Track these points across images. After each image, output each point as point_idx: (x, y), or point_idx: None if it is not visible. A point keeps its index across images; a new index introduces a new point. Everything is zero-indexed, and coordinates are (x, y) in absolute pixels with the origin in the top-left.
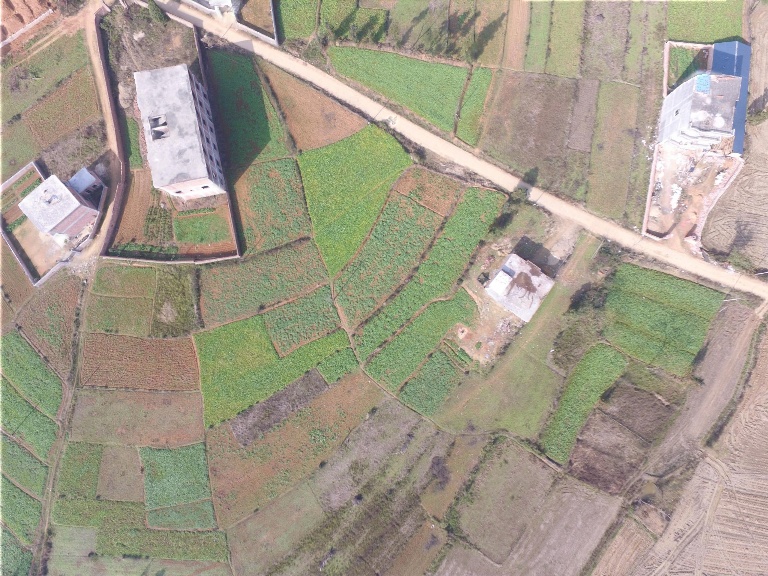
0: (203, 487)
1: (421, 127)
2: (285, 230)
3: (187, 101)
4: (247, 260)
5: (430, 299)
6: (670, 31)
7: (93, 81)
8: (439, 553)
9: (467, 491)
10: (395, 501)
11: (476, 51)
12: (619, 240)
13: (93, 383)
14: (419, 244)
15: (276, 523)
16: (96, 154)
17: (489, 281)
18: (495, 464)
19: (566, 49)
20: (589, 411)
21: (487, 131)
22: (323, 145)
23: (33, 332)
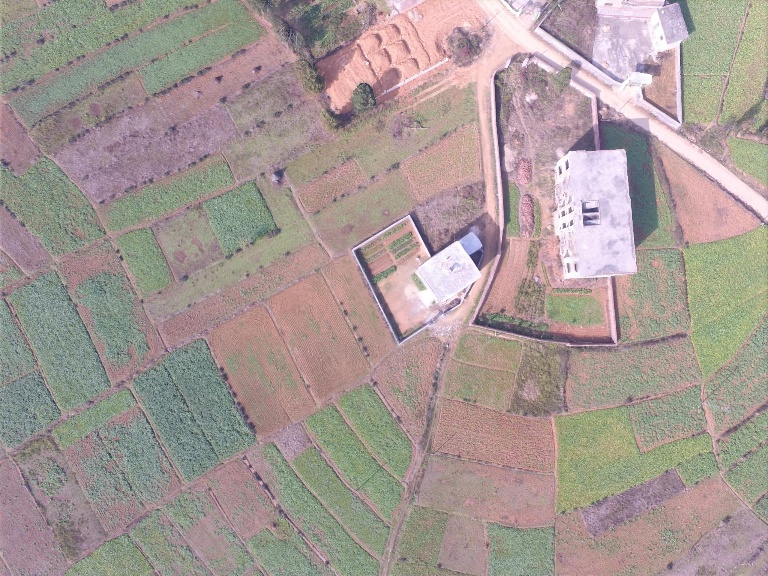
0: (548, 571)
1: None
2: (663, 323)
3: (623, 189)
4: (619, 348)
5: None
6: None
7: (478, 139)
8: None
9: None
10: None
11: None
12: None
13: (446, 450)
14: None
15: None
16: (472, 215)
17: None
18: None
19: None
20: None
21: None
22: (712, 240)
23: (388, 390)
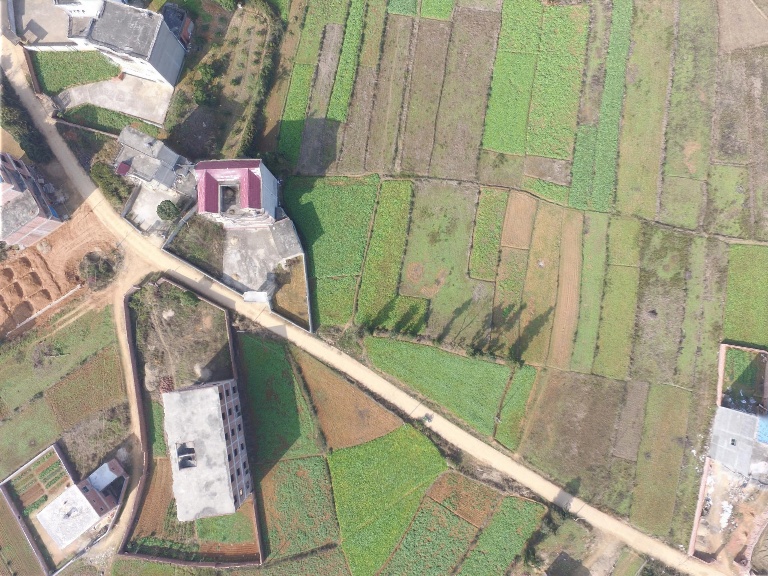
0: None
1: (459, 427)
2: (311, 535)
3: (217, 428)
4: (270, 564)
5: None
6: (727, 330)
7: (119, 360)
8: None
9: None
10: None
11: (520, 347)
12: (663, 559)
13: None
14: (451, 558)
15: None
16: (119, 438)
17: None
18: None
19: (615, 348)
20: None
21: (528, 435)
22: (355, 444)
23: None
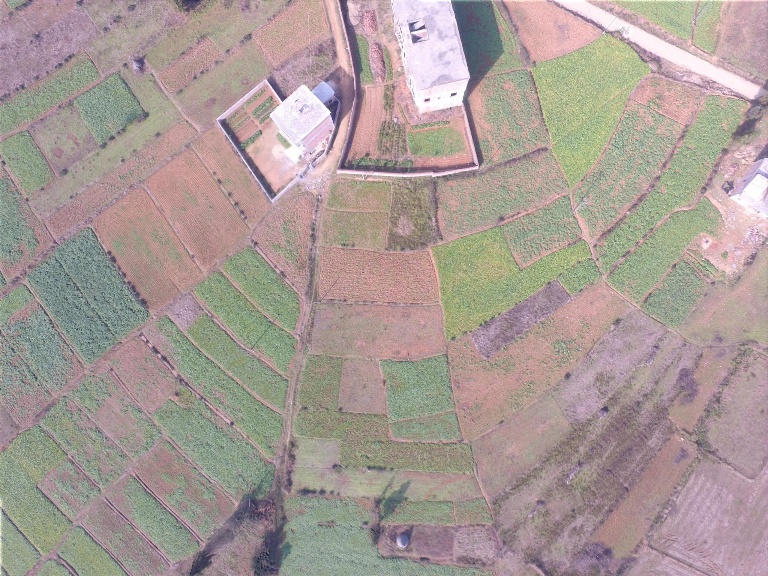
0: (447, 399)
1: (656, 36)
2: (522, 141)
3: (445, 4)
4: (484, 172)
5: (673, 209)
6: None
7: None
8: (690, 467)
9: (719, 403)
10: (642, 414)
11: None
12: None
13: (331, 297)
14: (660, 153)
15: (521, 435)
16: (326, 71)
17: (734, 189)
18: (742, 378)
19: None
20: None
21: (725, 38)
22: (557, 56)
23: (269, 248)
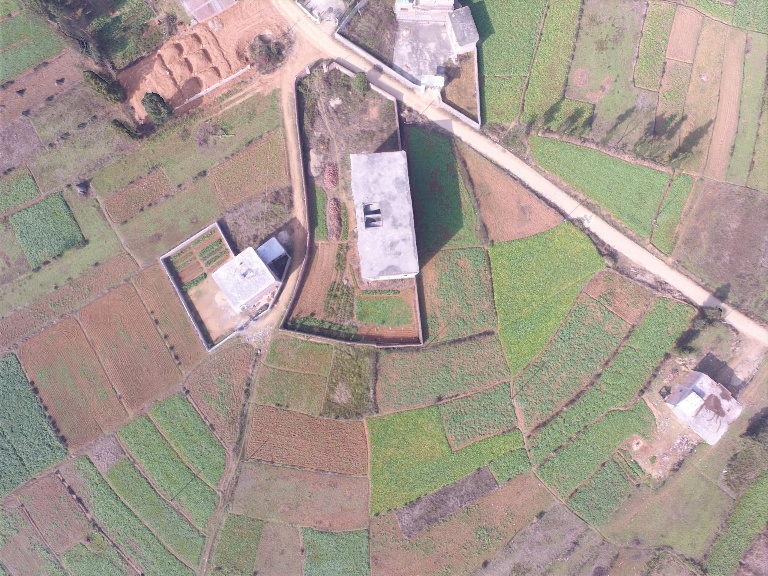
0: (363, 575)
1: (616, 229)
2: (470, 322)
3: (404, 191)
4: (428, 348)
5: (609, 408)
6: None
7: (284, 144)
8: None
9: None
10: None
11: None
12: None
13: (259, 457)
14: (604, 351)
15: None
16: (281, 221)
17: (670, 395)
18: None
19: None
20: (754, 535)
21: (682, 240)
22: (516, 238)
23: (201, 398)
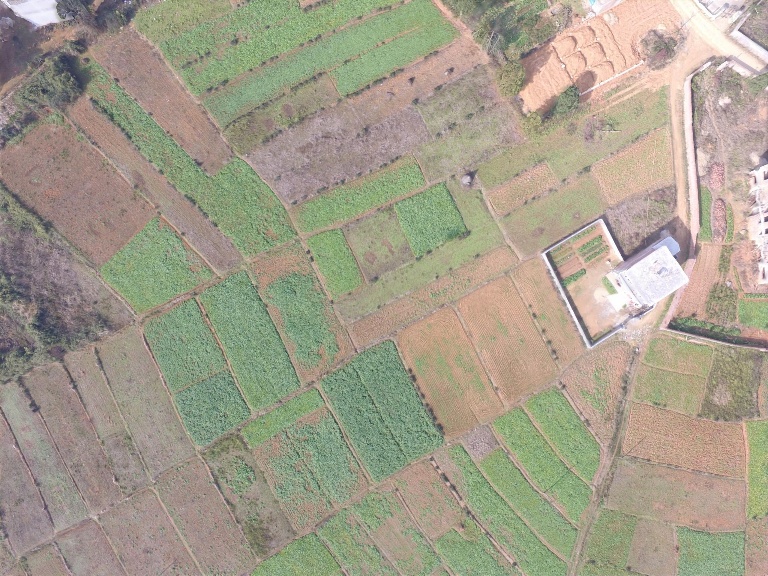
0: (738, 575)
1: None
2: None
3: None
4: None
5: None
6: None
7: (670, 142)
8: None
9: None
10: None
11: None
12: None
13: (635, 454)
14: None
15: None
16: (663, 219)
17: None
18: None
19: None
20: None
21: None
22: None
23: (577, 393)
